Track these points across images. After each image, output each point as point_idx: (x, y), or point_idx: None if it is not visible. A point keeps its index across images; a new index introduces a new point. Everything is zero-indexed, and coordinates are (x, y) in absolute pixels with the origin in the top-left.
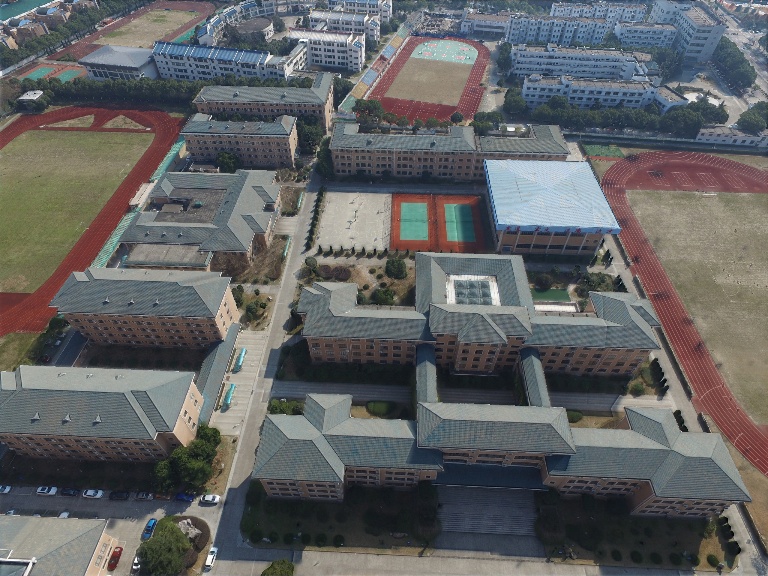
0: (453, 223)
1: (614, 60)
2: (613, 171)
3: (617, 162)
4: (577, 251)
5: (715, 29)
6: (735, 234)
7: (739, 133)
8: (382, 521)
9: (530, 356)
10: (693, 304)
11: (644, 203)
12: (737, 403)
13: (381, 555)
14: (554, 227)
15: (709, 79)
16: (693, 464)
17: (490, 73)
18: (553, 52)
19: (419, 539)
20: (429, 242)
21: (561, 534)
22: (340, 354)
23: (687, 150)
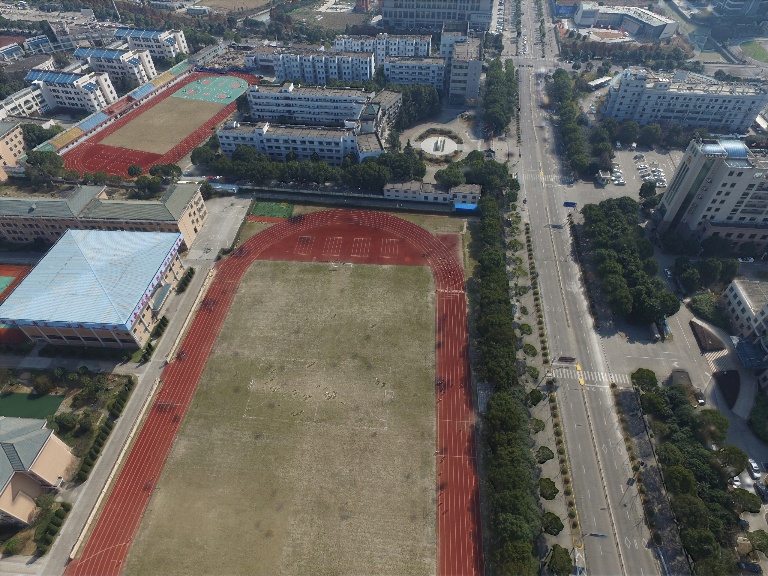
0: None
1: (352, 101)
2: (261, 236)
3: (276, 224)
4: (118, 344)
5: (471, 65)
6: (329, 321)
7: (430, 189)
8: None
9: None
10: (195, 420)
11: (260, 278)
12: (120, 571)
13: None
14: (50, 322)
15: (469, 119)
16: None
17: (236, 114)
18: (284, 93)
19: None
20: None
21: None
22: None
23: (369, 208)
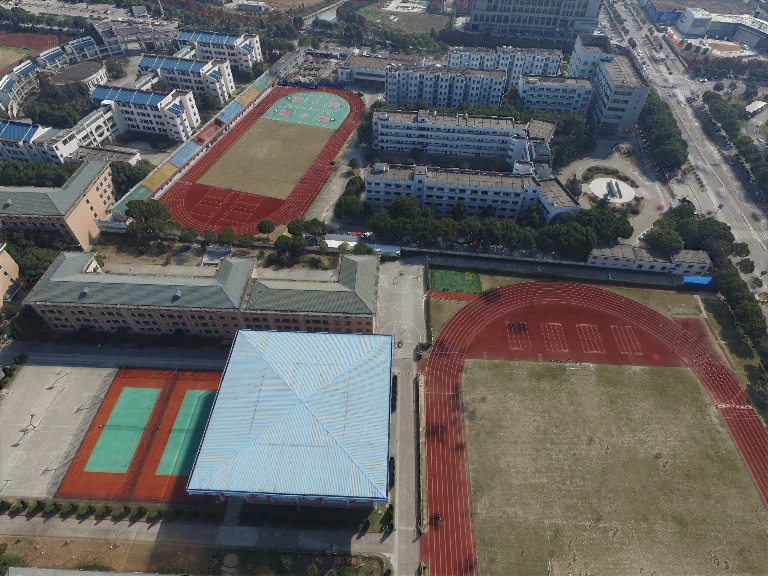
0: (181, 433)
1: (502, 133)
2: (458, 321)
3: (469, 303)
4: (345, 503)
5: (637, 91)
6: (605, 457)
7: (645, 256)
8: None
9: None
10: None
11: (484, 388)
12: None
13: None
14: (278, 495)
15: (630, 154)
16: None
17: (352, 144)
18: (422, 123)
19: None
20: (125, 478)
21: None
22: None
23: (573, 280)
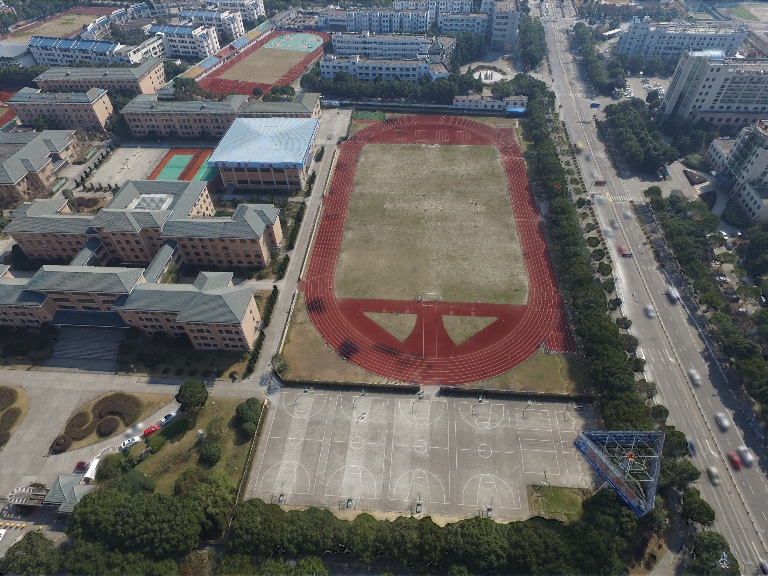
0: (205, 168)
1: (417, 43)
2: (366, 130)
3: (375, 124)
4: (287, 186)
5: (511, 15)
6: (430, 174)
7: (488, 99)
8: (13, 350)
9: (165, 245)
10: (353, 222)
11: (373, 153)
12: (333, 284)
13: (1, 369)
14: (250, 163)
15: (509, 59)
16: (207, 299)
17: (320, 58)
18: (364, 38)
19: (32, 360)
20: None
21: (130, 356)
22: (44, 250)
23: (442, 114)
